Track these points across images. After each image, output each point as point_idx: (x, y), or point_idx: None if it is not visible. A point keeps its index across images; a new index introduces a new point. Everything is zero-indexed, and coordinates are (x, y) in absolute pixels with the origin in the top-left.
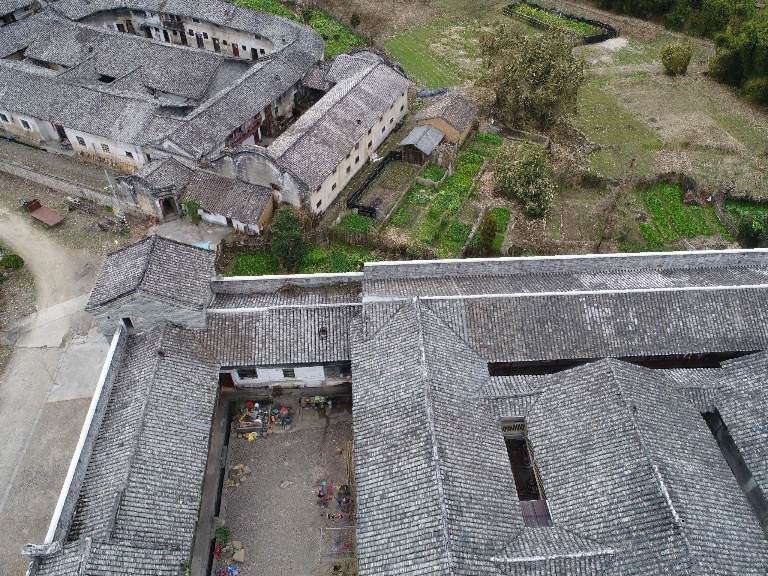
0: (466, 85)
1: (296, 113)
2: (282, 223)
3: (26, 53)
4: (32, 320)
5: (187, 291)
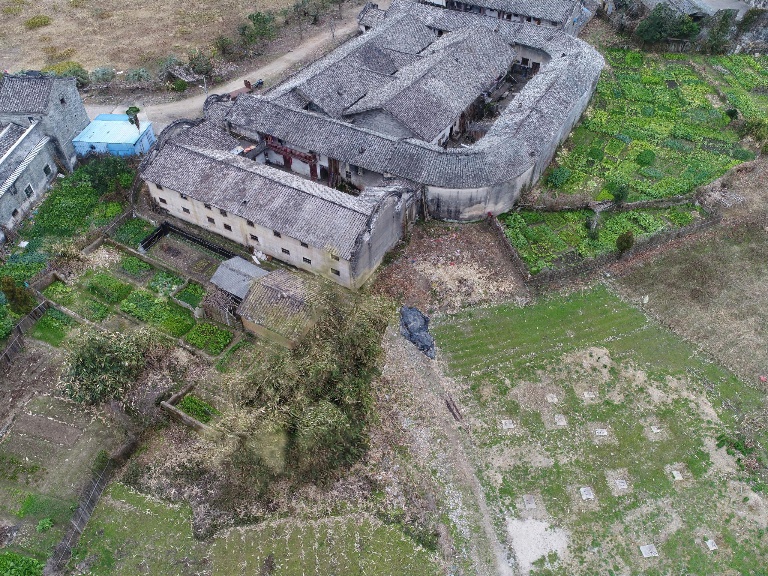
0: (448, 378)
1: (342, 188)
2: (104, 160)
3: (444, 34)
4: (137, 106)
5: (5, 101)
